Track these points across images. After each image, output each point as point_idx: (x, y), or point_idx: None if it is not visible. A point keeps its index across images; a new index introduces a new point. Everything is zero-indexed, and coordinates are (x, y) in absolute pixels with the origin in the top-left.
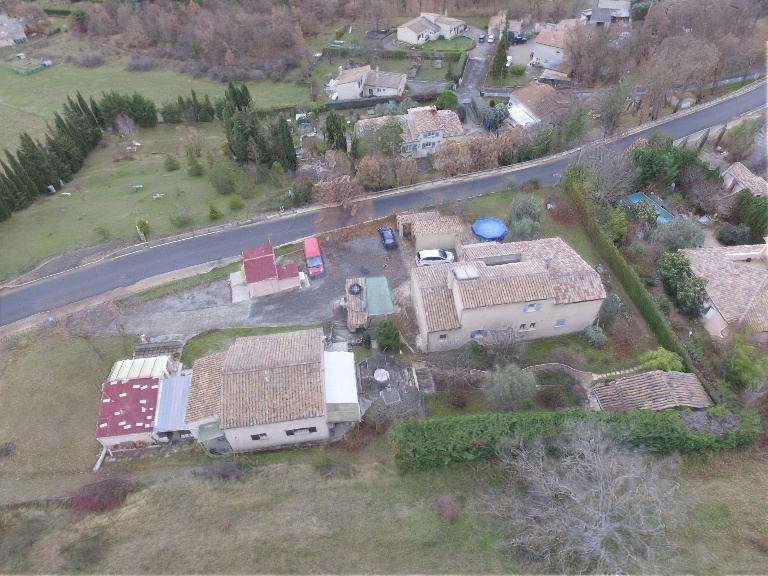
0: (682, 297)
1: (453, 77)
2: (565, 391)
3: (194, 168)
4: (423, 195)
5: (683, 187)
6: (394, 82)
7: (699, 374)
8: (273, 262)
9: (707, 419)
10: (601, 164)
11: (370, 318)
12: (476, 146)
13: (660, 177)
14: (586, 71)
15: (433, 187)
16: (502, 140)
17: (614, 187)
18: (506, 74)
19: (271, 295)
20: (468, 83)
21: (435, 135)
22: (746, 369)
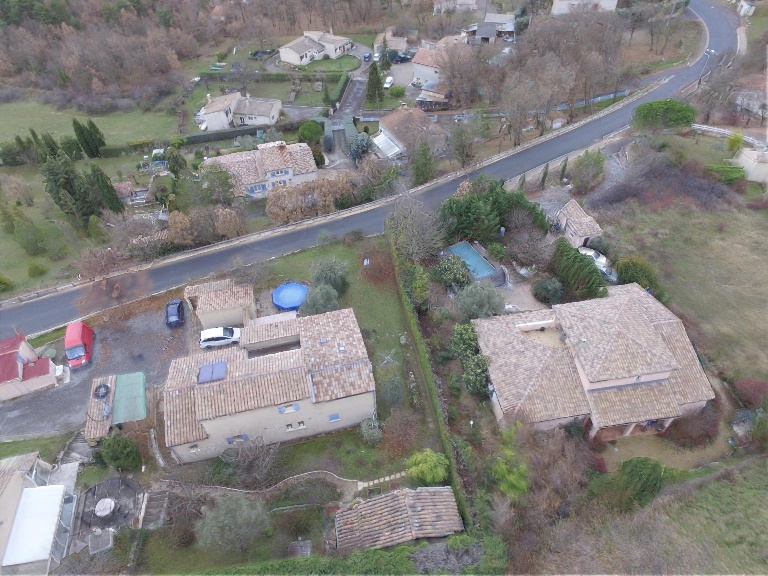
0: (465, 380)
1: (330, 101)
2: (316, 512)
3: (9, 224)
4: (248, 249)
5: (511, 232)
6: (265, 109)
7: (458, 485)
8: (16, 360)
9: (444, 554)
10: (413, 216)
11: (117, 426)
12: (308, 190)
13: (480, 225)
14: (461, 92)
15: (259, 239)
16: (339, 182)
17: (432, 238)
18: (382, 97)
19: (19, 398)
20: (346, 107)
21: (284, 173)
22: (504, 479)
